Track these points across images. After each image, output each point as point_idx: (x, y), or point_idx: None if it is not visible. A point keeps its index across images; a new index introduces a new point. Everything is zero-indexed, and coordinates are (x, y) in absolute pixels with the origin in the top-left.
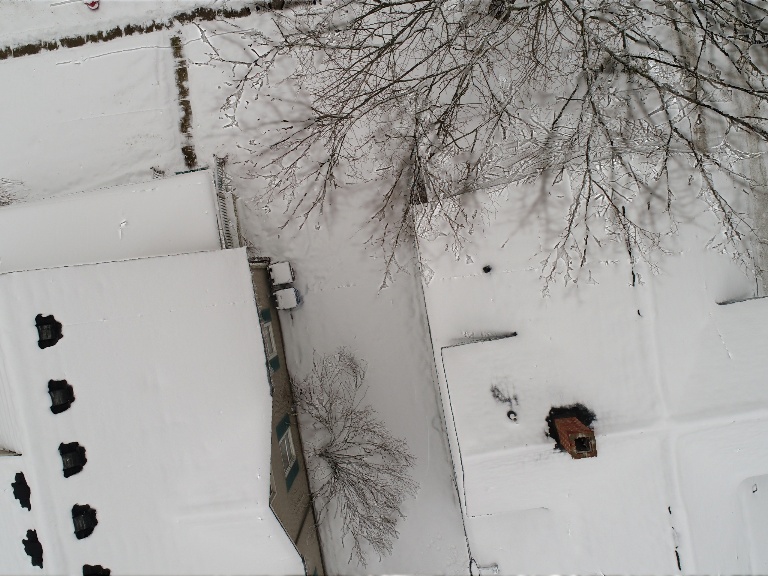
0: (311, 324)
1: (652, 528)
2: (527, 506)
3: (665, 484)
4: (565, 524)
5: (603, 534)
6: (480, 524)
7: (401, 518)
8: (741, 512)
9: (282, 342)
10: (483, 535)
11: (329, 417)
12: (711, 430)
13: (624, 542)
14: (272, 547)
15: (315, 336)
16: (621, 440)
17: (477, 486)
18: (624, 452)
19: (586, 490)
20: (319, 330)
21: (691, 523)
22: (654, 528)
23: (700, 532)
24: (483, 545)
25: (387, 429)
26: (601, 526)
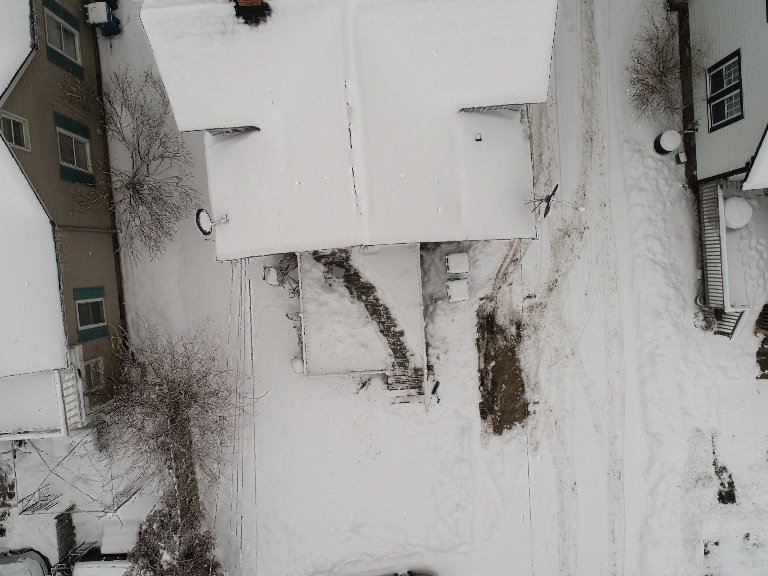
0: (130, 55)
1: (333, 112)
2: (234, 116)
3: (344, 59)
4: (274, 142)
5: (300, 138)
6: (216, 176)
7: (204, 260)
8: (453, 146)
9: (99, 71)
10: (218, 188)
11: (132, 139)
12: (395, 7)
13: (313, 138)
14: (6, 183)
15: (133, 68)
16: (303, 10)
17: (168, 66)
18: (311, 32)
19: (287, 94)
20: (138, 63)
21: (366, 100)
22: (334, 111)
23: (380, 119)
24: (218, 199)
25: (162, 116)
26: (298, 130)
